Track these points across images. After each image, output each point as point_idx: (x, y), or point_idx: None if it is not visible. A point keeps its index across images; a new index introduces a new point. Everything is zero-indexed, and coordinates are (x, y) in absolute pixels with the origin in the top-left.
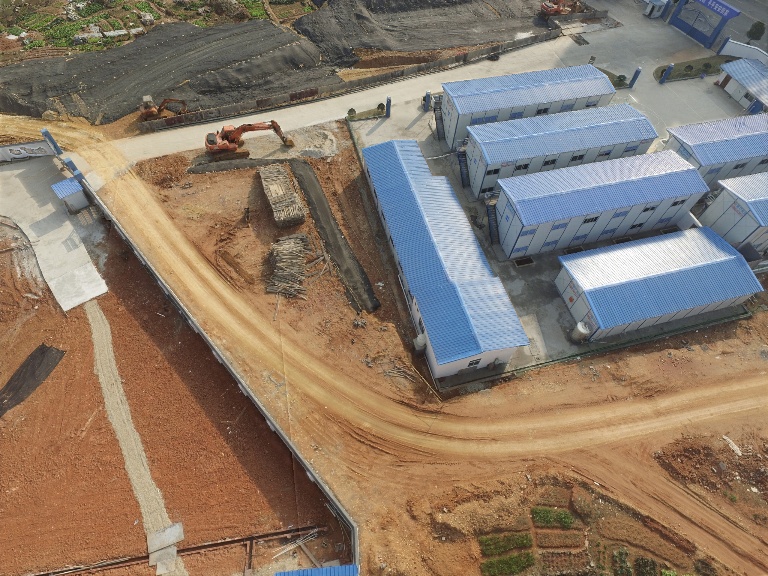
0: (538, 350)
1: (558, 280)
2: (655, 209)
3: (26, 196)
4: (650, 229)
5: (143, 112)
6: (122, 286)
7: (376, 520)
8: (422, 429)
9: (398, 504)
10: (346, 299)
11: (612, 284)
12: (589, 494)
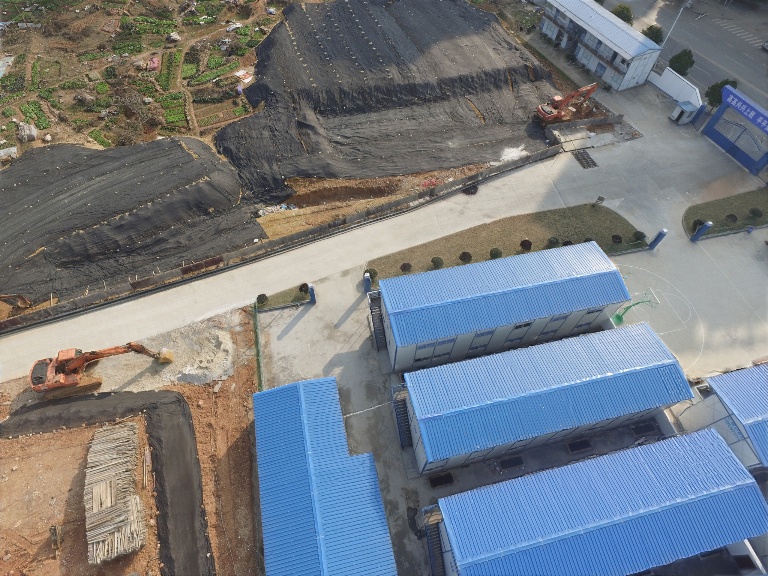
0: None
1: None
2: None
3: None
4: None
5: None
6: None
7: None
8: None
9: None
10: None
11: None
12: None
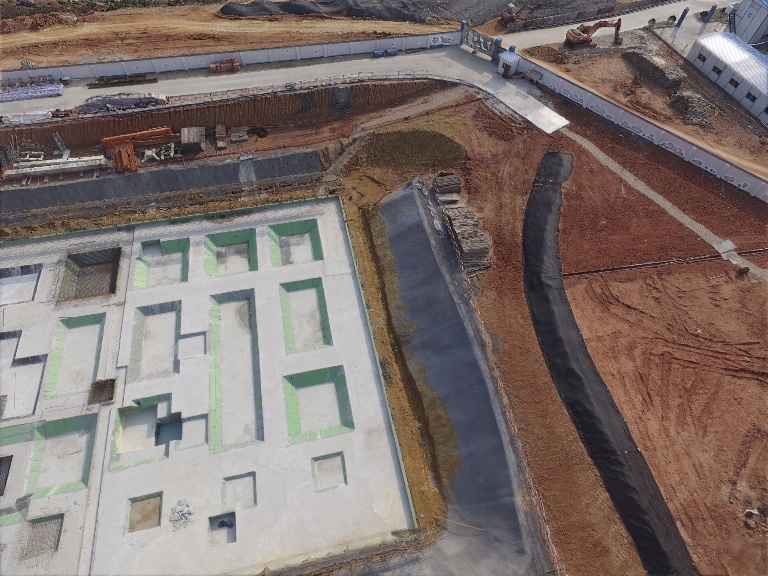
0: None
1: None
2: None
3: (464, 68)
4: None
5: (508, 16)
6: (578, 120)
7: None
8: None
9: None
10: (744, 129)
11: None
12: None
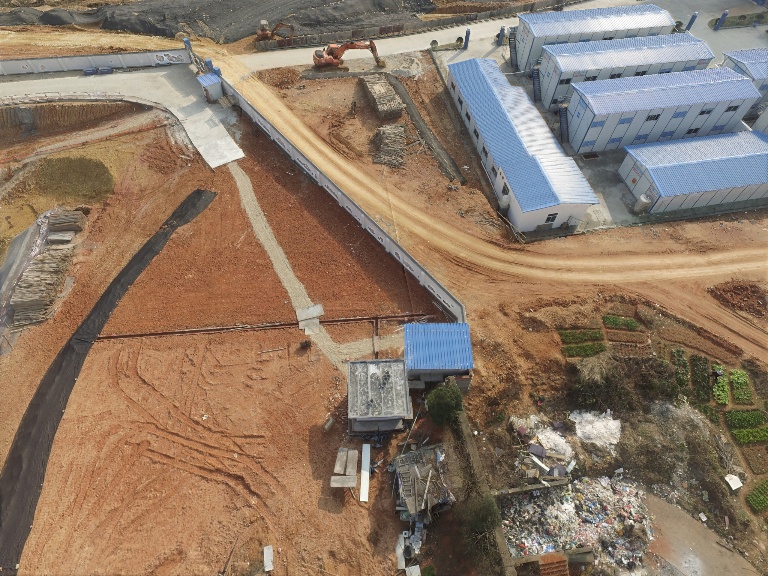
0: (604, 218)
1: (622, 168)
2: (711, 113)
3: (172, 90)
4: None
5: (260, 34)
6: (256, 153)
7: (475, 314)
8: (509, 260)
9: (492, 306)
10: (440, 171)
11: (672, 164)
12: (651, 310)
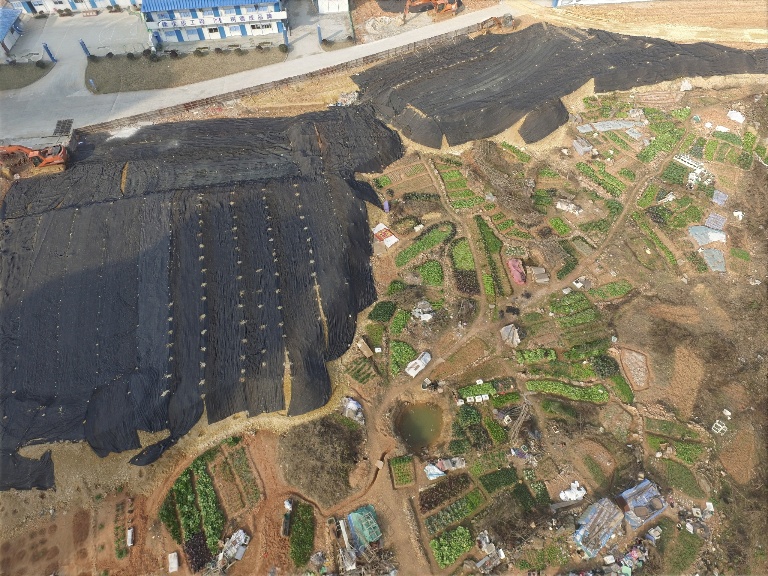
0: None
1: None
2: None
3: None
4: None
5: None
6: None
7: None
8: None
9: None
10: None
11: None
12: None
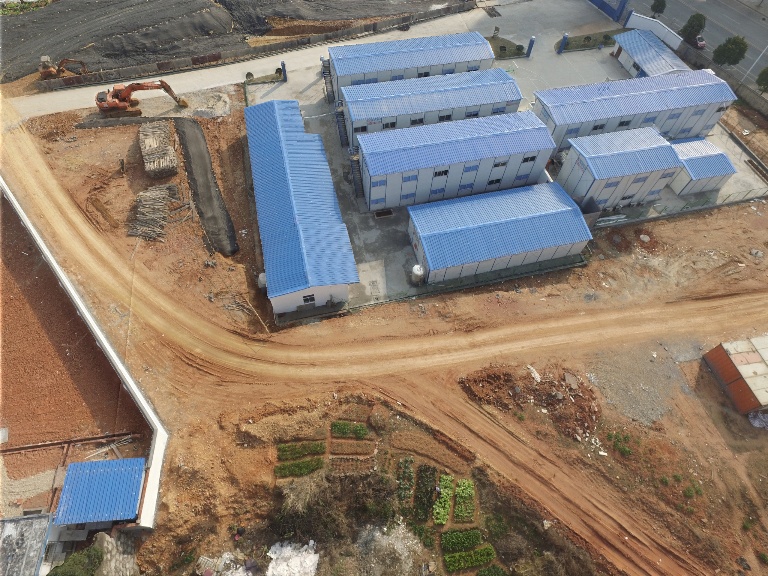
0: (378, 291)
1: (409, 229)
2: (506, 165)
3: None
4: (511, 186)
5: (41, 72)
6: None
7: (187, 429)
8: (248, 355)
9: (211, 417)
10: (202, 242)
11: (448, 230)
12: (388, 411)
